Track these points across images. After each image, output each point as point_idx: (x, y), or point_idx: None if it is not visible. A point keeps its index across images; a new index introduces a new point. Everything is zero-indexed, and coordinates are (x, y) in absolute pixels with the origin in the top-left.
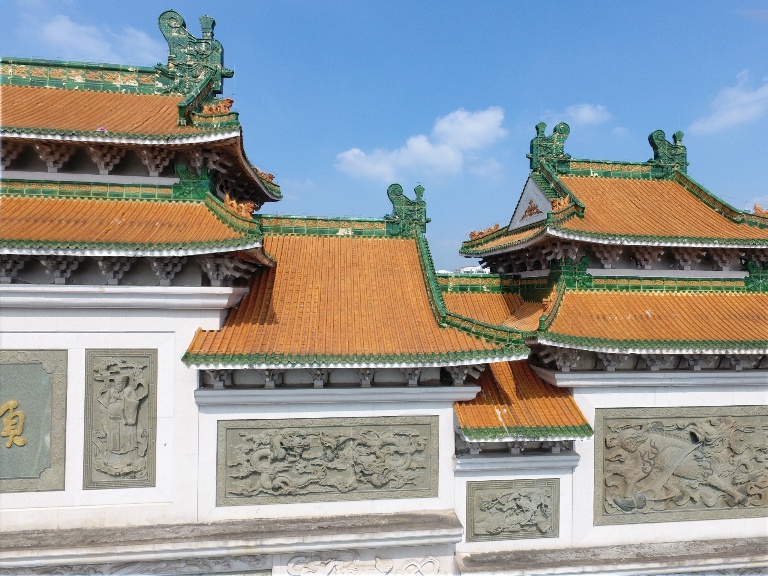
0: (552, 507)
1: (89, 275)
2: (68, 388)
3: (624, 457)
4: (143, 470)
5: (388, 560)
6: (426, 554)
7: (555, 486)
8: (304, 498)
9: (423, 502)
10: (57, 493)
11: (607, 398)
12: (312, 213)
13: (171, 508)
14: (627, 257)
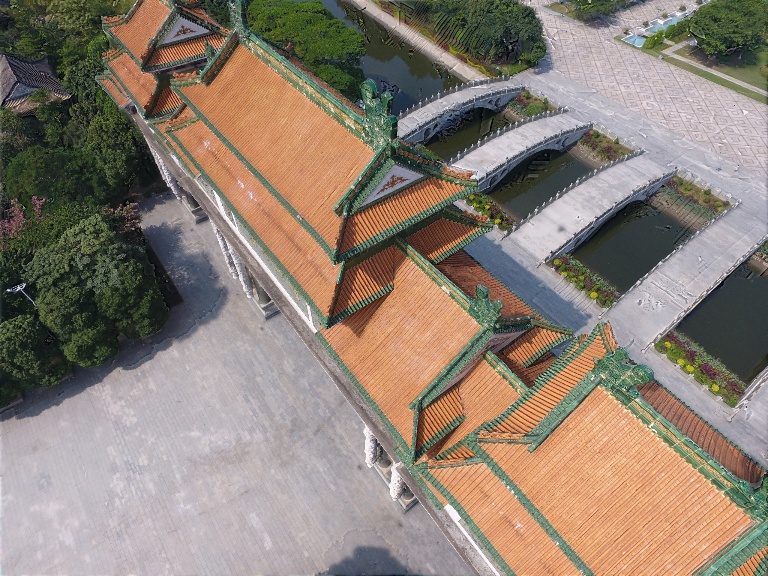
0: None
1: None
2: None
3: None
4: None
5: None
6: None
7: None
8: None
9: None
10: None
11: None
12: None
13: None
14: None
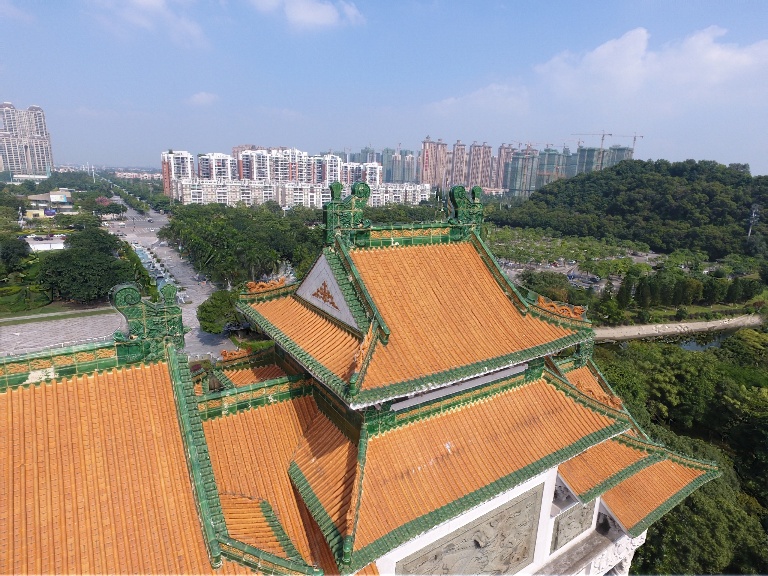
0: None
1: None
2: None
3: None
4: None
5: None
6: None
7: None
8: None
9: None
10: None
11: (407, 548)
12: None
13: None
14: None
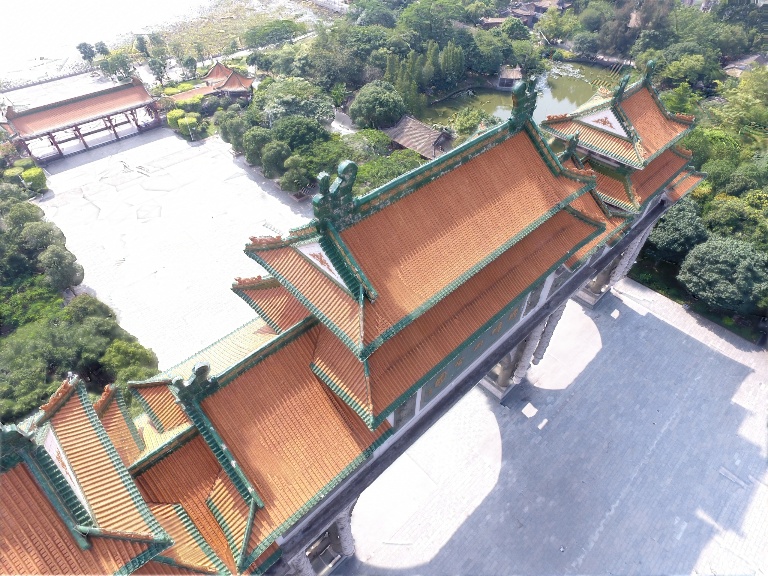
0: None
1: None
2: None
3: None
4: None
5: None
6: None
7: None
8: None
9: None
10: None
11: None
12: (270, 340)
13: None
14: None
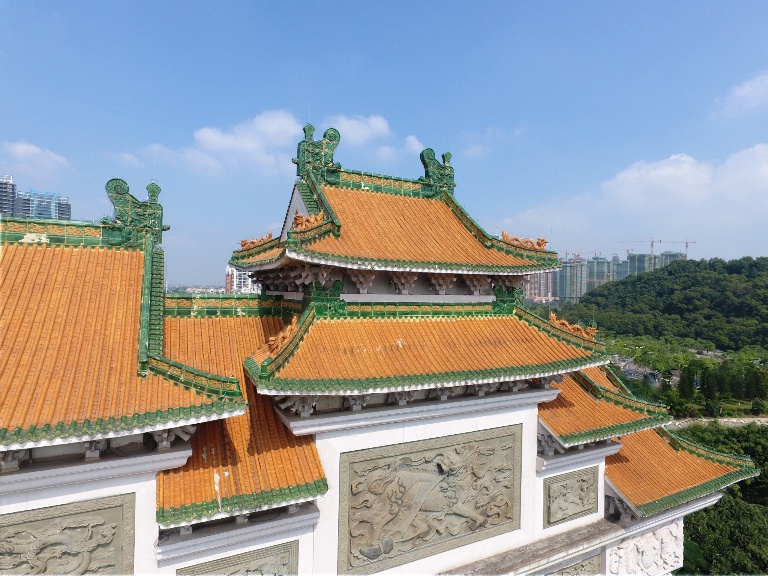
0: (289, 575)
1: None
2: None
3: (371, 502)
4: None
5: None
6: None
7: (293, 550)
8: None
9: None
10: None
11: (353, 440)
12: None
13: None
14: (388, 280)
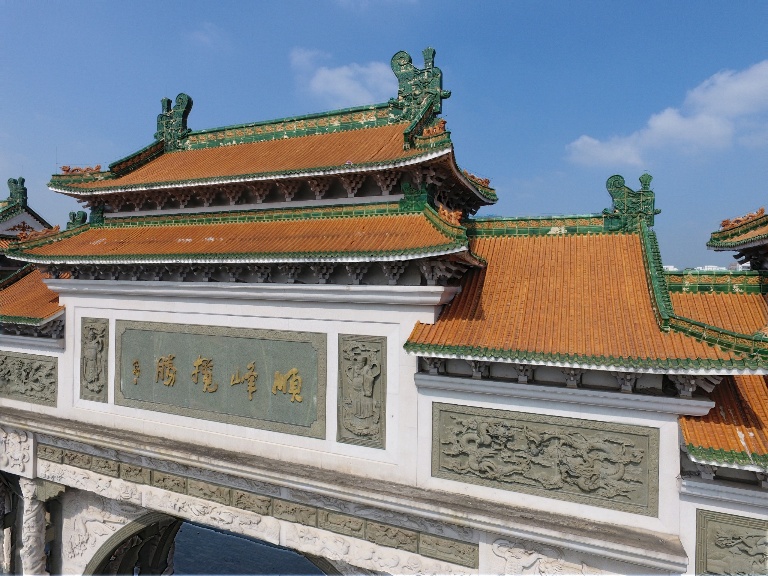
0: None
1: (341, 277)
2: (327, 363)
3: None
4: (377, 434)
5: (596, 569)
6: (642, 575)
7: None
8: (509, 486)
9: (639, 519)
10: (321, 441)
11: None
12: None
13: (397, 470)
14: None
